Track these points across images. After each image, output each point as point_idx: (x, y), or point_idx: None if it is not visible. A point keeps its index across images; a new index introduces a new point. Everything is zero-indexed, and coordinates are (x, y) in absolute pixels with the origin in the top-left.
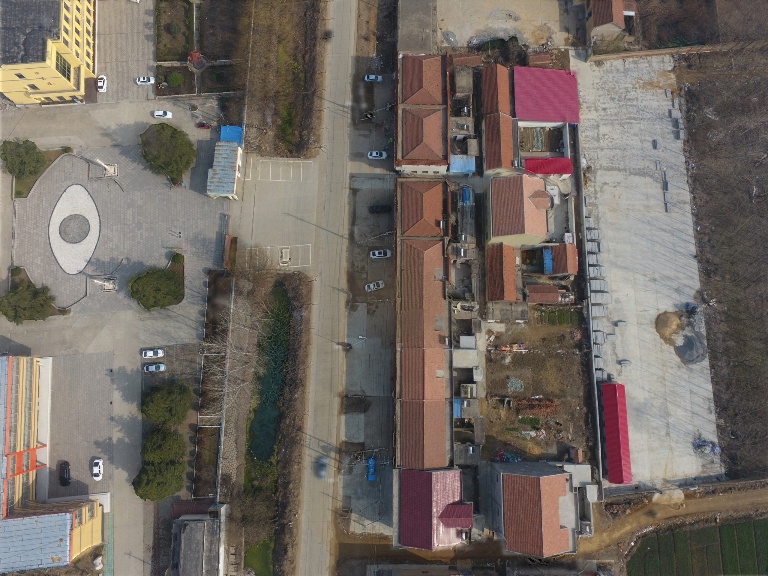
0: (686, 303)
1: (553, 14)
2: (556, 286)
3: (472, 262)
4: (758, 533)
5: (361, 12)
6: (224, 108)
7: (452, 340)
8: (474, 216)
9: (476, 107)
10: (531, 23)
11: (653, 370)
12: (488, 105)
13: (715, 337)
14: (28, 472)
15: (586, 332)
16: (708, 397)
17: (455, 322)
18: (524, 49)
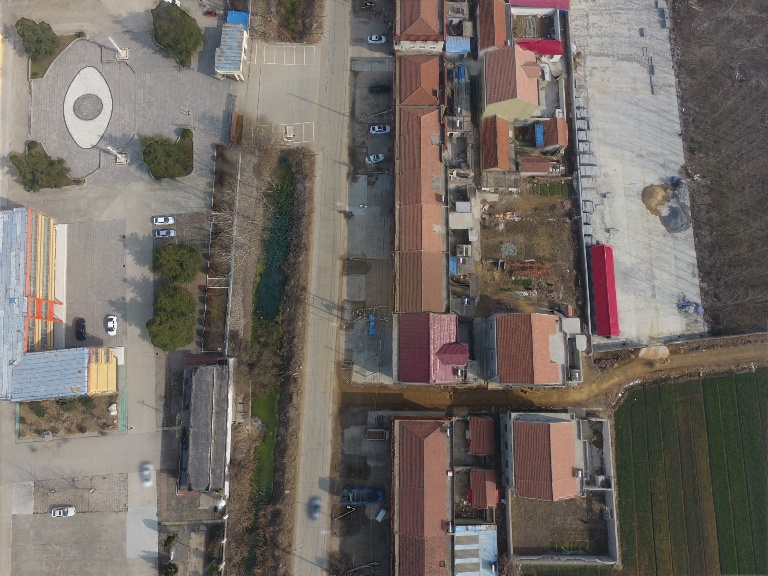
0: (671, 177)
1: None
2: (547, 159)
3: (467, 133)
4: (739, 386)
5: None
6: None
7: (448, 200)
8: (469, 92)
9: None
10: None
11: (640, 238)
12: None
13: (699, 209)
14: (46, 321)
15: (576, 202)
16: (692, 262)
17: (451, 186)
18: None
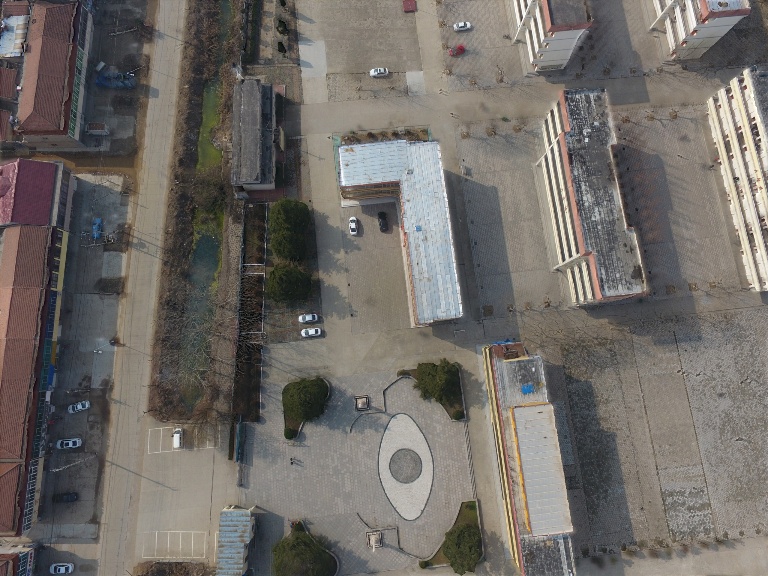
0: None
1: None
2: None
3: None
4: None
5: None
6: None
7: None
8: None
9: None
10: None
11: None
12: None
13: None
14: None
15: None
16: None
17: None
18: None
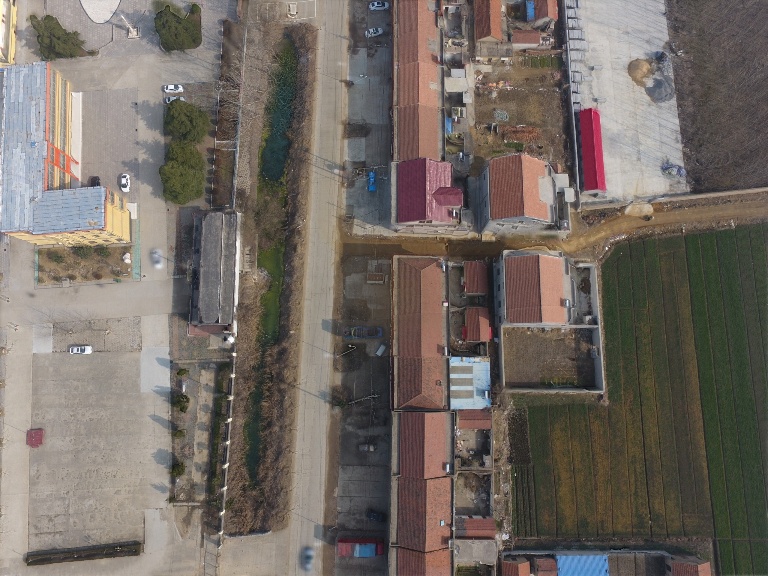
0: (656, 52)
1: None
2: None
3: (462, 6)
4: (720, 241)
5: None
6: None
7: (444, 63)
8: None
9: None
10: None
11: (626, 107)
12: None
13: (682, 81)
14: (64, 172)
15: (565, 73)
16: (675, 129)
17: (446, 52)
18: None
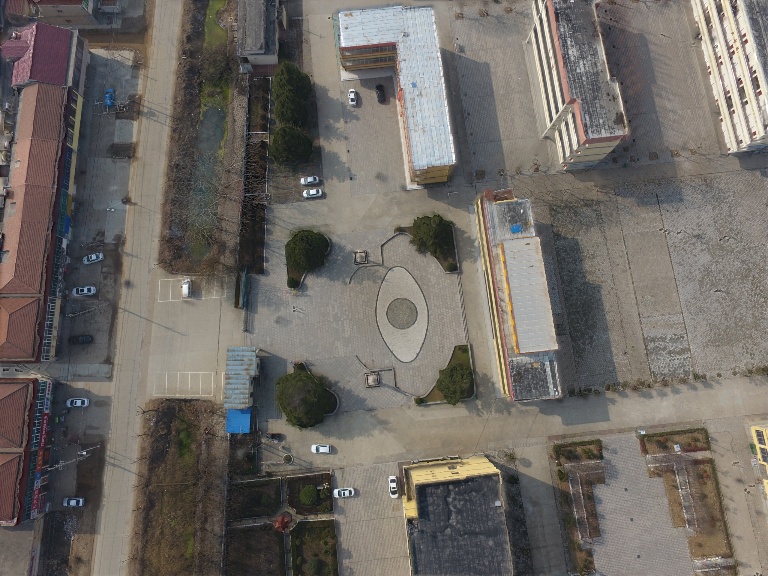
0: None
1: None
2: None
3: None
4: None
5: None
6: (250, 458)
7: None
8: None
9: None
10: None
11: None
12: None
13: None
14: None
15: None
16: None
17: None
18: None
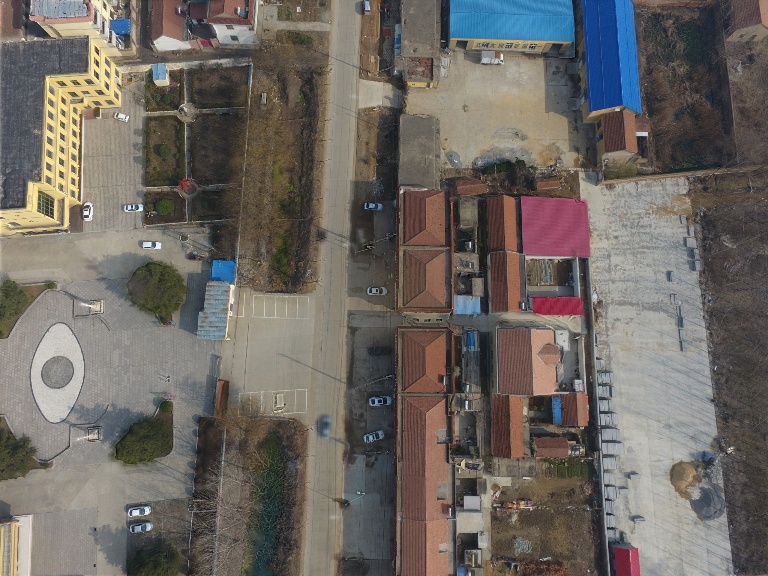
0: (703, 452)
1: (562, 132)
2: (565, 436)
3: (477, 415)
4: None
5: (360, 132)
6: (216, 239)
7: (456, 507)
8: (479, 362)
9: (481, 238)
10: (539, 142)
11: (668, 527)
12: (494, 239)
13: (733, 489)
14: None
15: (597, 486)
16: (726, 557)
17: (459, 484)
18: (531, 171)
